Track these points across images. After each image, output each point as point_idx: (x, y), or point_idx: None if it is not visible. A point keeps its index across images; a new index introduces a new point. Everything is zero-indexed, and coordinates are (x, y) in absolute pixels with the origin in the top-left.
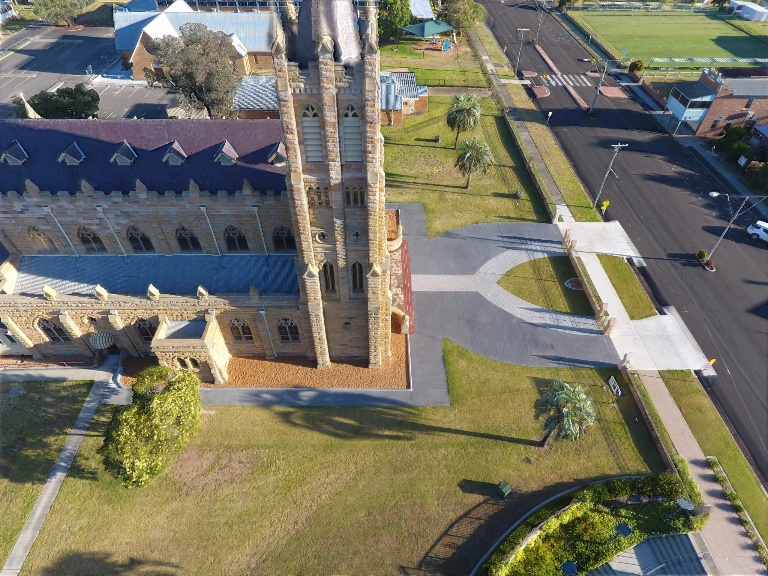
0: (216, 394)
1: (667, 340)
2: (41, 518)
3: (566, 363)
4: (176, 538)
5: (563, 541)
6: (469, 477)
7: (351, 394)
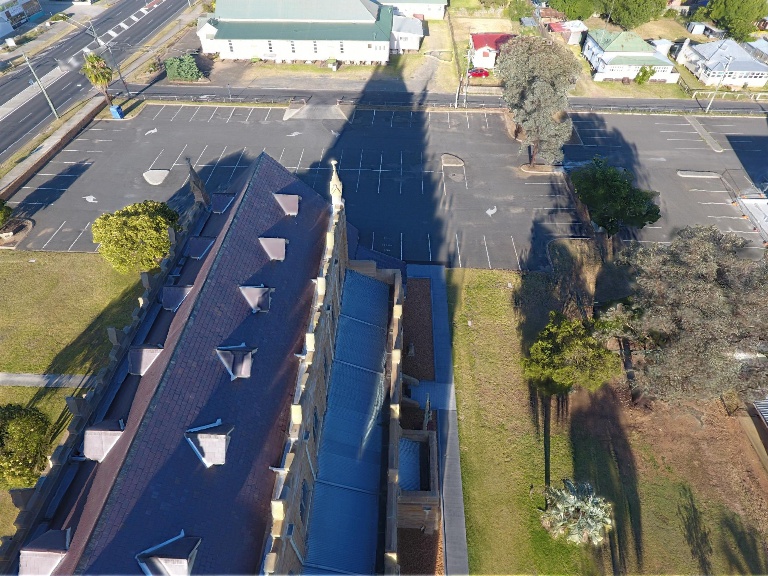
0: None
1: None
2: (10, 383)
3: None
4: None
5: None
6: None
7: None
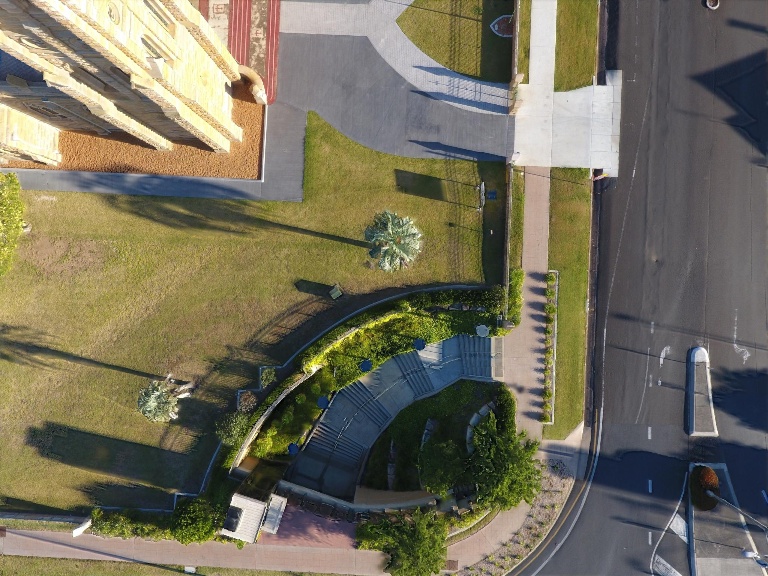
0: (53, 177)
1: (584, 126)
2: None
3: (446, 154)
4: (47, 315)
5: (382, 333)
6: (307, 278)
7: (197, 183)
